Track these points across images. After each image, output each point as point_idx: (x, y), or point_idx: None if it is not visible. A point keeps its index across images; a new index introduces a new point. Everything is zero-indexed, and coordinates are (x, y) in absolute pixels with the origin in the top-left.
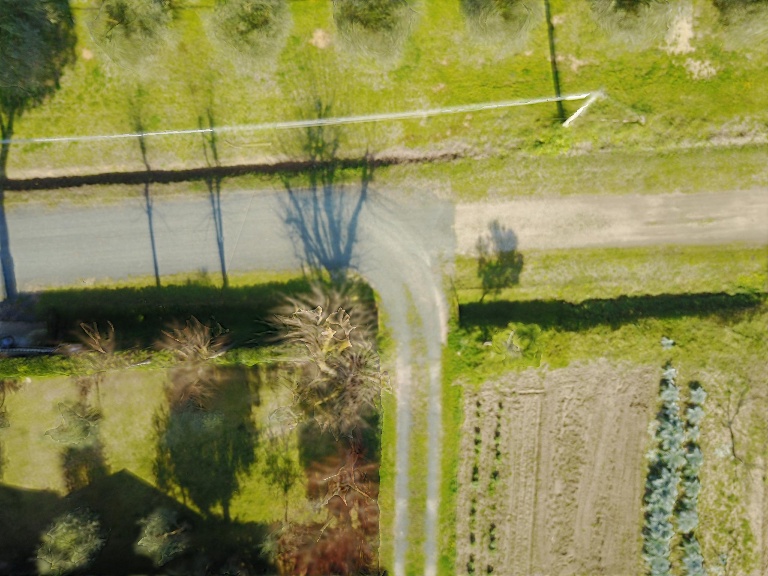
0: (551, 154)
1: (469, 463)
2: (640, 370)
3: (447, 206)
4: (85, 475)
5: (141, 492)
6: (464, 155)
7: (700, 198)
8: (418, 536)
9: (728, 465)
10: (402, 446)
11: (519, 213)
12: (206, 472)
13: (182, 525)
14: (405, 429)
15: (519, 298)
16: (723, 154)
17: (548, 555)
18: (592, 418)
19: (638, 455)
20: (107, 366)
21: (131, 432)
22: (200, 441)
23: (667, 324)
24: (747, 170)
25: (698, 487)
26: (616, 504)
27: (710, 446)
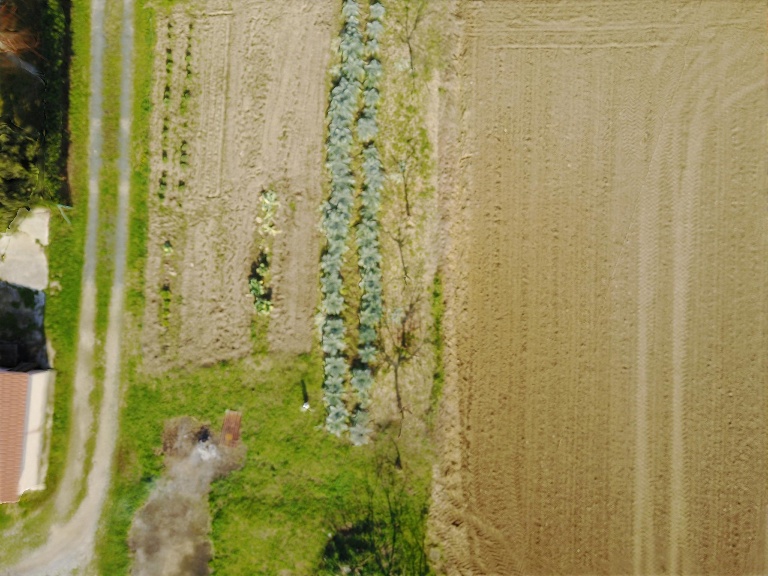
0: None
1: (161, 83)
2: None
3: None
4: None
5: None
6: None
7: None
8: (111, 153)
9: (407, 78)
10: (95, 68)
11: None
12: None
13: None
14: (98, 52)
15: None
16: None
17: (237, 169)
18: (278, 37)
19: (322, 71)
20: None
21: None
22: None
23: None
24: None
25: (376, 96)
26: (301, 118)
27: (389, 60)
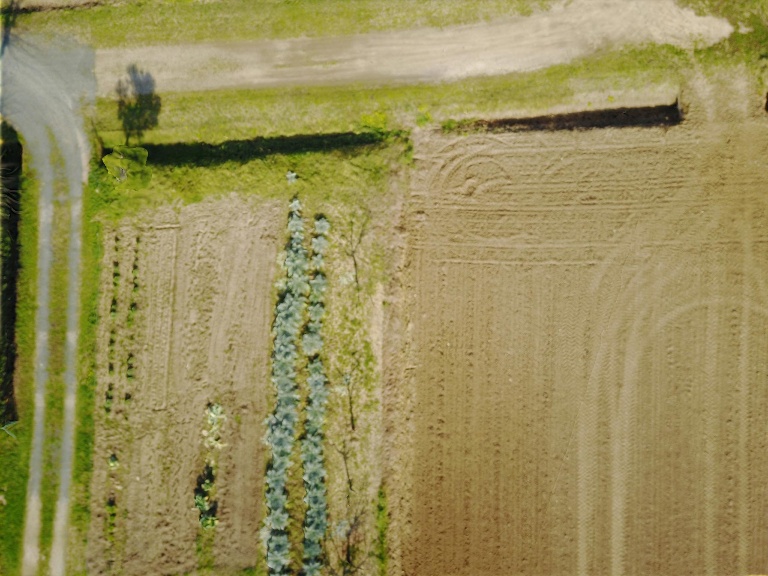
0: (185, 1)
1: (108, 296)
2: (270, 204)
3: (87, 51)
4: None
5: None
6: (104, 3)
7: (324, 42)
8: (57, 367)
9: (352, 291)
10: (42, 281)
11: (156, 57)
12: None
13: None
14: (45, 265)
15: (163, 141)
16: (344, 0)
17: (183, 382)
18: (225, 250)
19: (268, 284)
20: None
21: None
22: None
23: (292, 159)
24: (365, 15)
25: (321, 311)
26: (247, 331)
27: (335, 274)
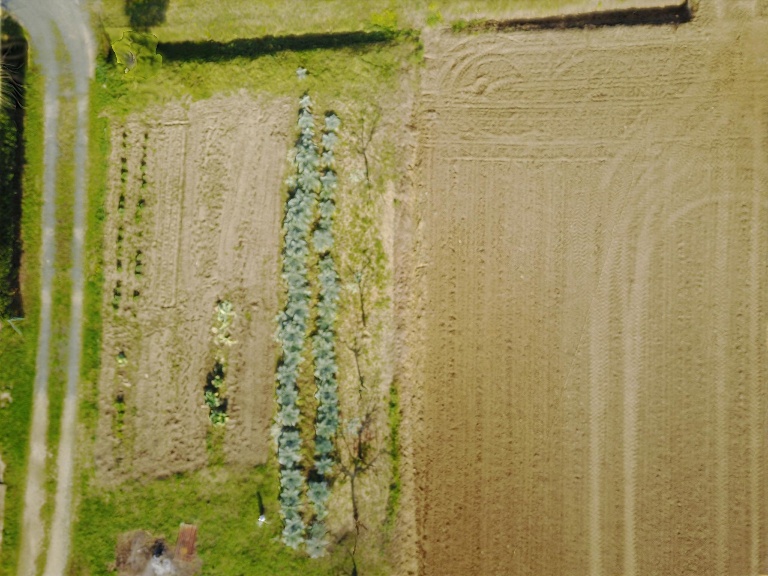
0: None
1: (116, 193)
2: (280, 101)
3: None
4: None
5: None
6: None
7: None
8: (64, 263)
9: (362, 189)
10: (49, 177)
11: None
12: None
13: None
14: (52, 161)
15: (171, 39)
16: None
17: (193, 279)
18: (235, 147)
19: (278, 181)
20: None
21: None
22: None
23: (303, 55)
24: None
25: (332, 207)
26: (257, 228)
27: (345, 171)
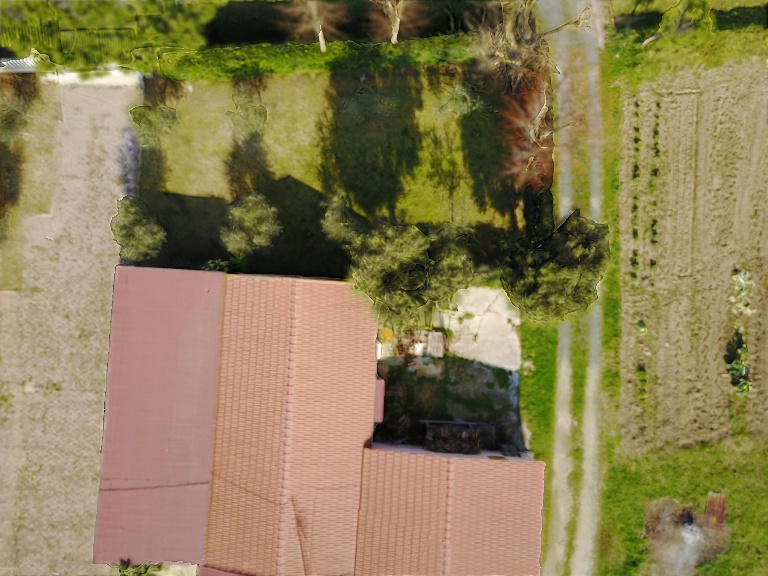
0: None
1: (630, 162)
2: None
3: None
4: (249, 183)
5: (306, 198)
6: None
7: None
8: None
9: None
10: (564, 147)
11: None
12: (371, 177)
13: (354, 221)
14: (567, 131)
15: None
16: None
17: (708, 248)
18: (747, 115)
19: None
20: (281, 56)
21: (295, 140)
22: (364, 147)
23: None
24: None
25: None
26: None
27: None
